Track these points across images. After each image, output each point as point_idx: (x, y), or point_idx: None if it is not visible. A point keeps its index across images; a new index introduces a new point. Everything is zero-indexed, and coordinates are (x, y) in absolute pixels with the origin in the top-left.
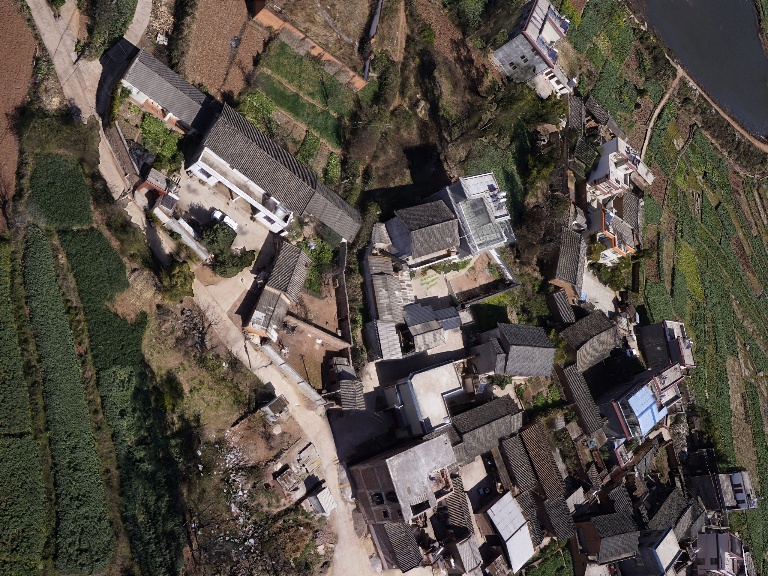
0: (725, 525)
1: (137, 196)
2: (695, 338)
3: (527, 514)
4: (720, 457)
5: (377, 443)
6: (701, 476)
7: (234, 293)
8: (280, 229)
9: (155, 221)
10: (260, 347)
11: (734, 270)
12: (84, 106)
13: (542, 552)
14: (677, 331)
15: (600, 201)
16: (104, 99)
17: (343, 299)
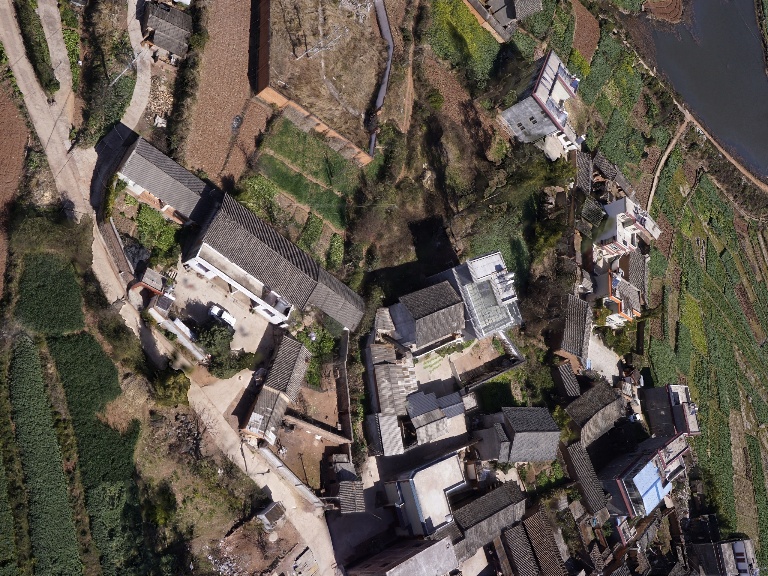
0: None
1: (131, 295)
2: (698, 394)
3: None
4: (722, 522)
5: (376, 545)
6: (703, 544)
7: (231, 393)
8: (280, 321)
9: (150, 321)
10: (257, 449)
11: (738, 319)
12: (77, 199)
13: None
14: (681, 394)
15: (606, 259)
16: (99, 190)
17: (344, 391)
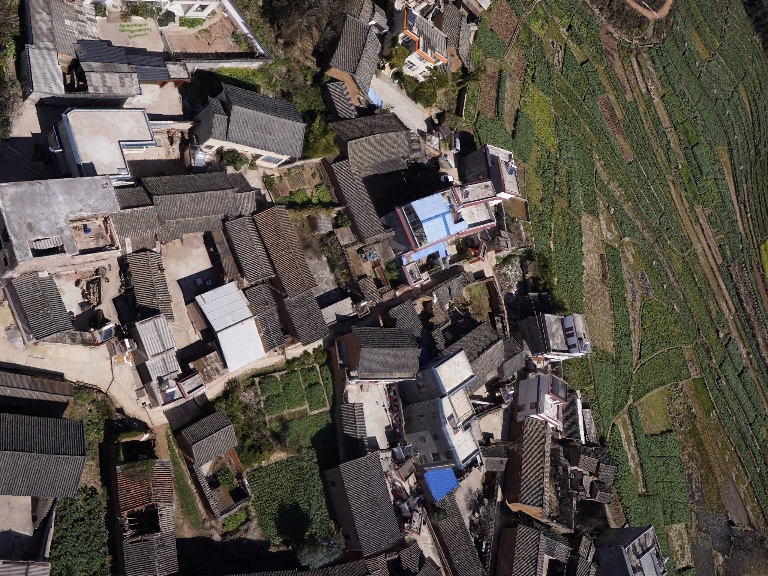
0: (558, 376)
1: None
2: (542, 186)
3: (259, 311)
4: (556, 304)
5: None
6: (528, 318)
7: None
8: None
9: None
10: None
11: (600, 130)
12: None
13: (288, 363)
14: (504, 160)
15: None
16: None
17: None
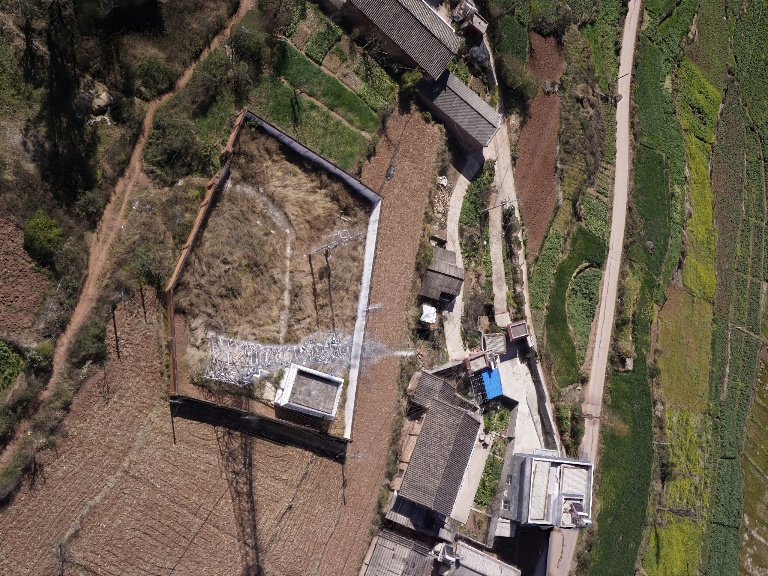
0: None
1: None
2: None
3: None
4: None
5: None
6: None
7: None
8: None
9: None
10: None
11: None
12: None
13: None
14: None
15: None
16: None
17: None
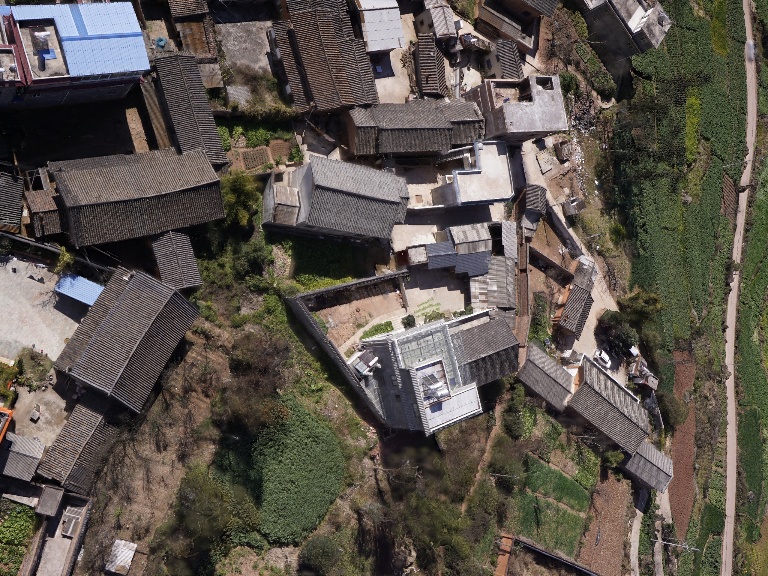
0: None
1: None
2: None
3: (346, 17)
4: None
5: None
6: None
7: None
8: None
9: None
10: None
11: None
12: None
13: None
14: None
15: None
16: None
17: None
